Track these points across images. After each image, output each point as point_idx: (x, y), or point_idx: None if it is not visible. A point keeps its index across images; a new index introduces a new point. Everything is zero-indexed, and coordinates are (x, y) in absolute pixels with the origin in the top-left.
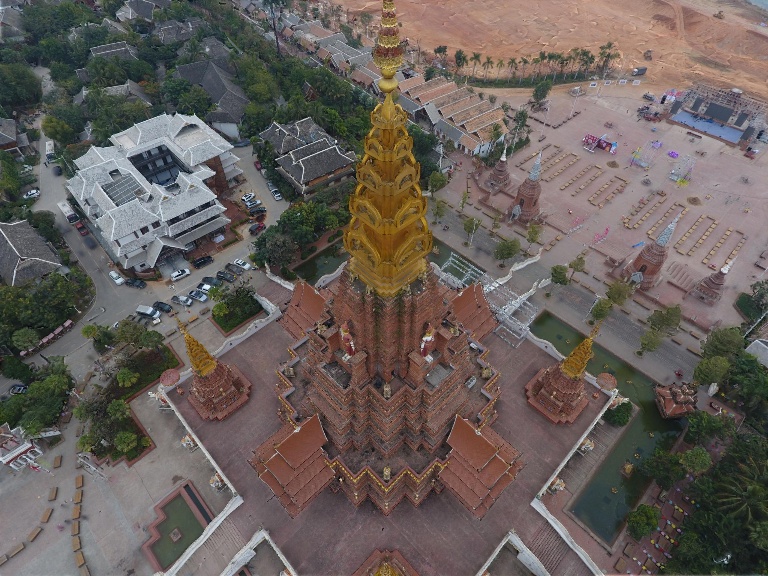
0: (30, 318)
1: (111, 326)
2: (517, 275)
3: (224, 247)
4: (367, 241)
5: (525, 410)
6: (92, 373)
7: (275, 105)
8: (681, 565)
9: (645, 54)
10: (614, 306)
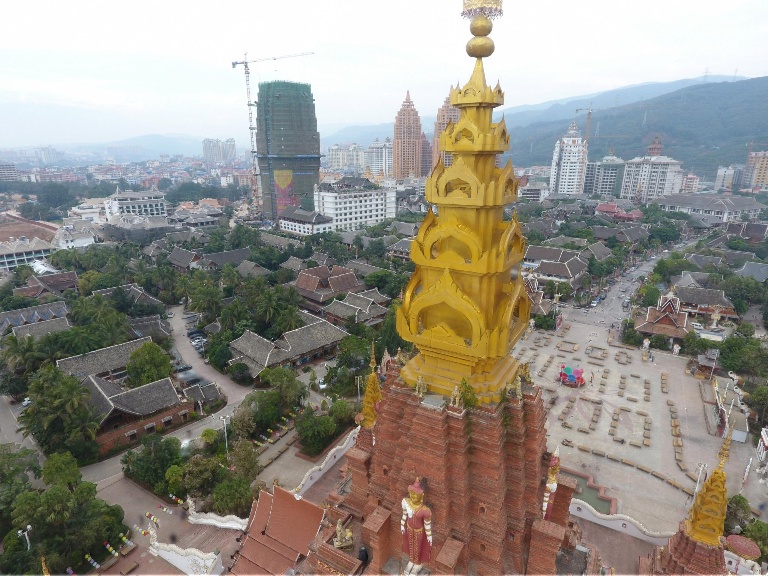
0: None
1: None
2: None
3: None
4: None
5: None
6: None
7: None
8: (67, 554)
9: None
10: None
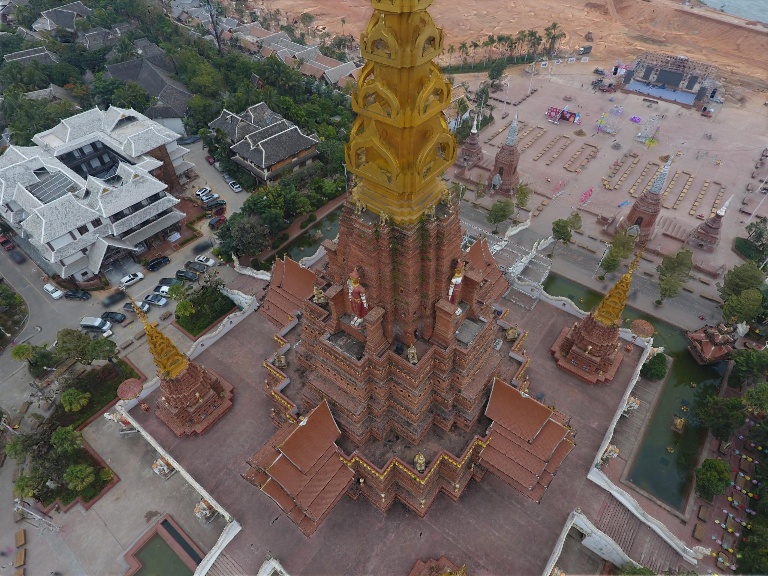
0: None
1: (50, 346)
2: (513, 240)
3: (181, 245)
4: (380, 144)
5: (556, 374)
6: (28, 400)
7: (222, 99)
8: None
9: (586, 36)
10: None
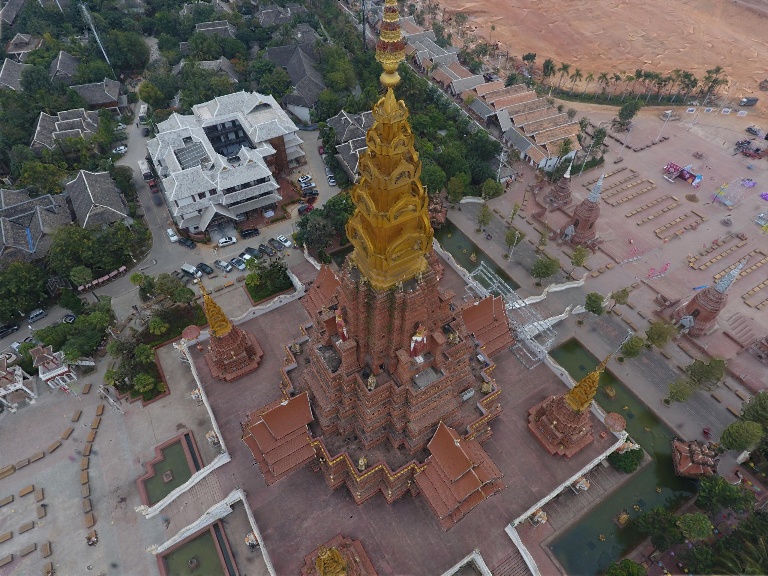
0: (91, 258)
1: None
2: (552, 296)
3: (272, 222)
4: (363, 231)
5: (523, 434)
6: (130, 316)
7: (350, 94)
8: None
9: (761, 84)
10: (654, 347)
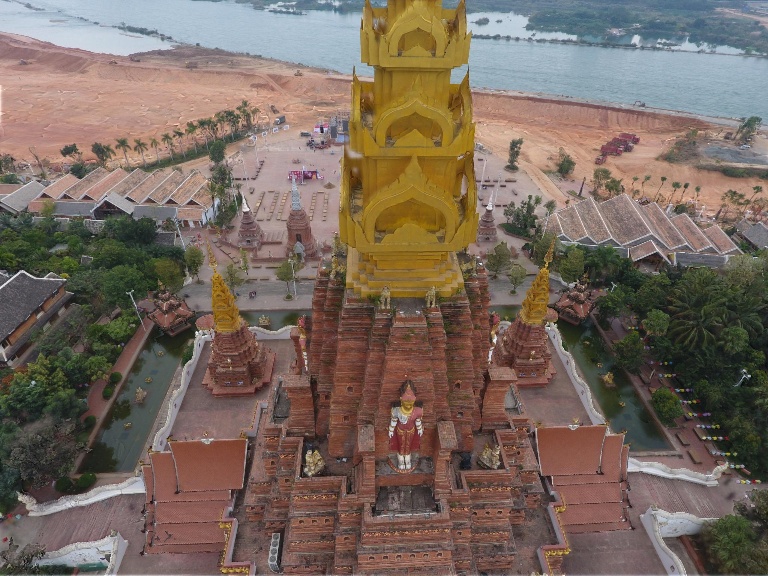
0: None
1: None
2: None
3: None
4: (425, 191)
5: None
6: None
7: None
8: (724, 411)
9: None
10: None
